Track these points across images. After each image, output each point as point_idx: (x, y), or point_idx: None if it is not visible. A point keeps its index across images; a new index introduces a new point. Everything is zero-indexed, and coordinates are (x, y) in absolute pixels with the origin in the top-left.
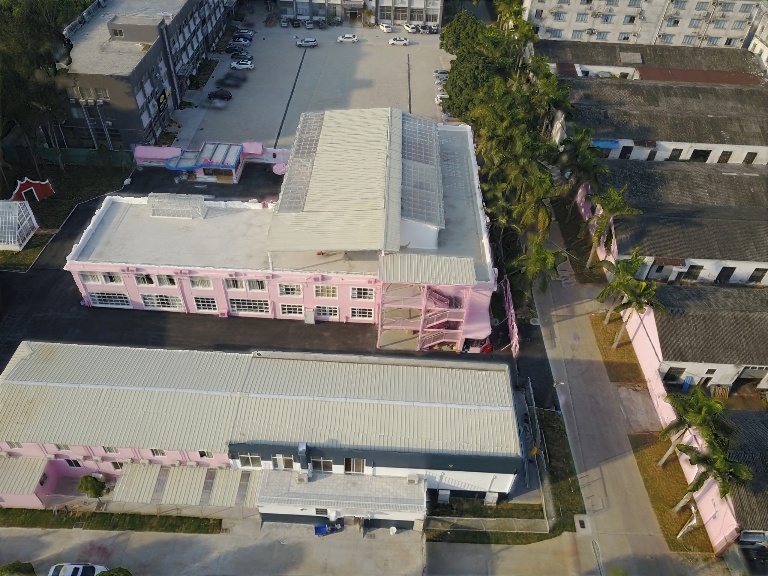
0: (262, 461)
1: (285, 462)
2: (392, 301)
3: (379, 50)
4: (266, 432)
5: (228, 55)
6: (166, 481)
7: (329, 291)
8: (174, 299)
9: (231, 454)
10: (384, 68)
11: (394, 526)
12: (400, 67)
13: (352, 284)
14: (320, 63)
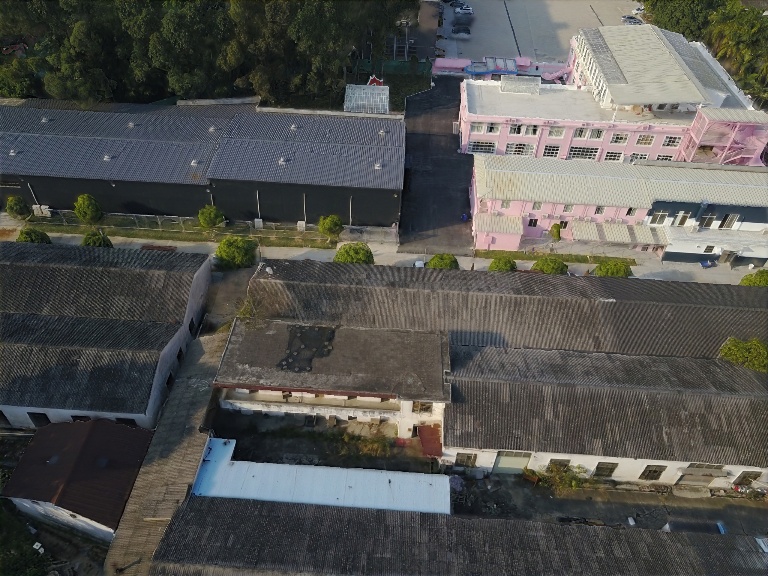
0: (667, 218)
1: (680, 220)
2: (706, 140)
3: (565, 2)
4: (671, 198)
5: (446, 4)
6: (603, 230)
7: (647, 140)
8: (529, 147)
9: (650, 211)
10: (577, 15)
11: (752, 263)
12: (589, 14)
13: (669, 133)
14: (523, 11)
